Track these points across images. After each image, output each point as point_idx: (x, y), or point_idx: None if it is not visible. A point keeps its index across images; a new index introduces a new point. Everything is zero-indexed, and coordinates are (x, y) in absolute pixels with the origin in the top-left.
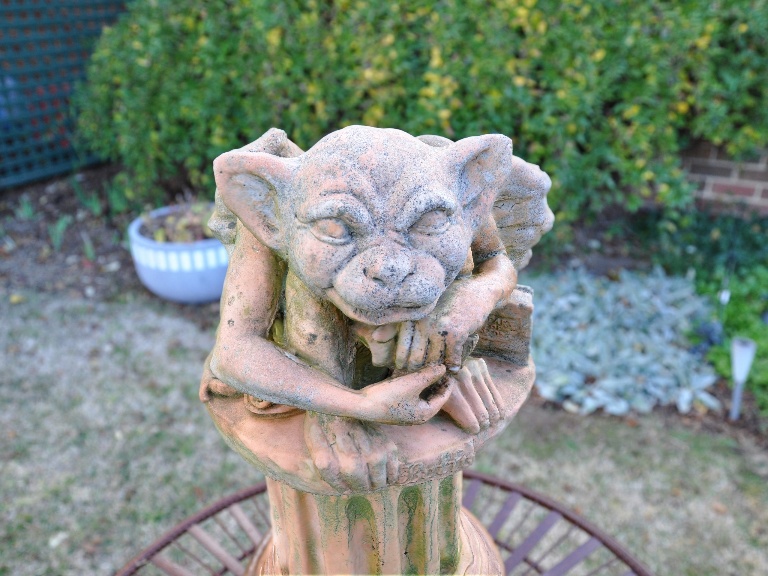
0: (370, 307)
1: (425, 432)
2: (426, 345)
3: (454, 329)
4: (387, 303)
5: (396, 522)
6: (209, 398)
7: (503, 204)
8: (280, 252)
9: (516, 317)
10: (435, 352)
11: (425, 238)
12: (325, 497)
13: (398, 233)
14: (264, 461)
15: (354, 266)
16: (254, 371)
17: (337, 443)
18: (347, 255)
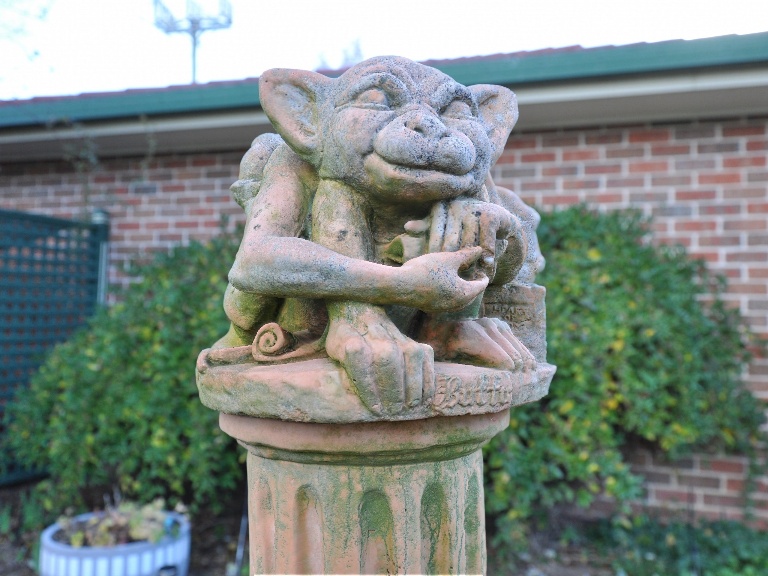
0: (412, 153)
1: (457, 364)
2: (460, 229)
3: (487, 210)
4: (427, 152)
5: (419, 535)
6: (208, 365)
7: None
8: (315, 152)
9: (529, 301)
10: (470, 233)
11: (456, 119)
12: (334, 492)
13: (432, 107)
14: (277, 389)
15: (395, 121)
16: (284, 247)
17: (369, 331)
18: (388, 117)
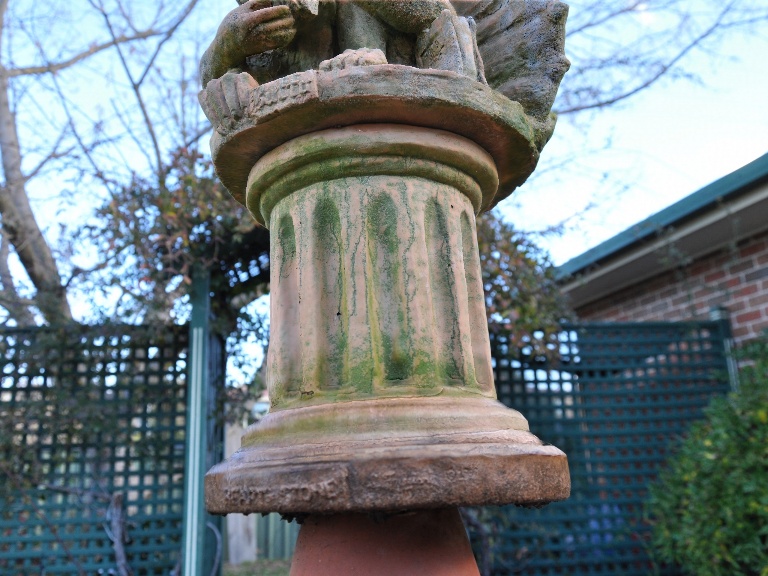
0: None
1: None
2: None
3: None
4: None
5: (311, 242)
6: None
7: (501, 5)
8: None
9: (439, 29)
10: None
11: None
12: None
13: None
14: None
15: None
16: None
17: None
18: None
